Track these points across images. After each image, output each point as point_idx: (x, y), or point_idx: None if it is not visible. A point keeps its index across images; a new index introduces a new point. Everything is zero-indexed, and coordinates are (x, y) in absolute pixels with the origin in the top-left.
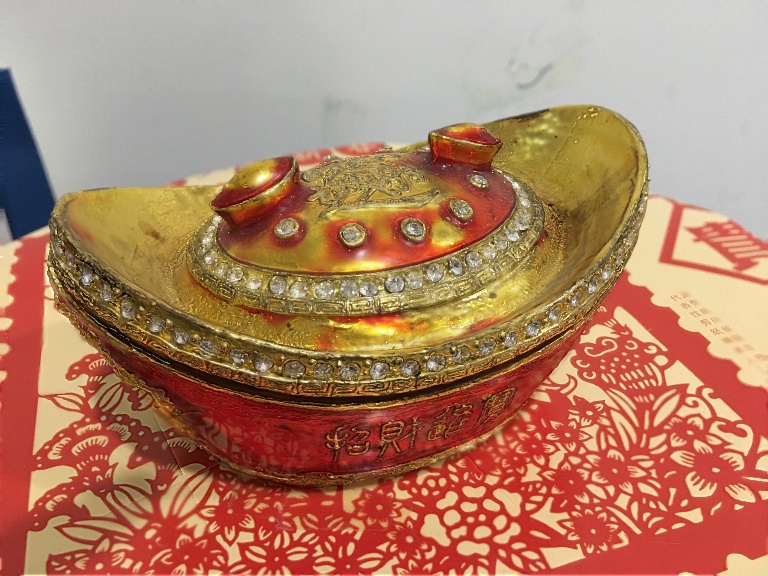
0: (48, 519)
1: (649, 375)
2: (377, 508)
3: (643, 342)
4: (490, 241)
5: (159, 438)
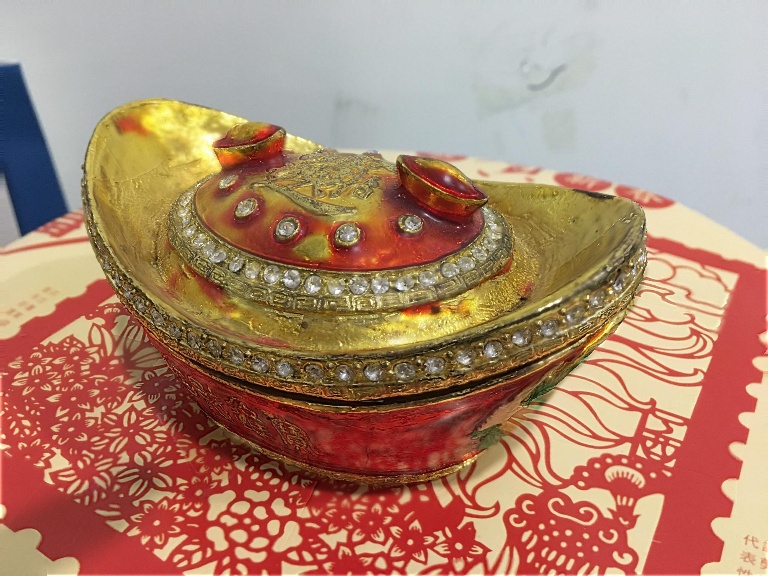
0: (97, 316)
1: (576, 574)
2: (215, 457)
3: (628, 545)
4: (346, 278)
5: None
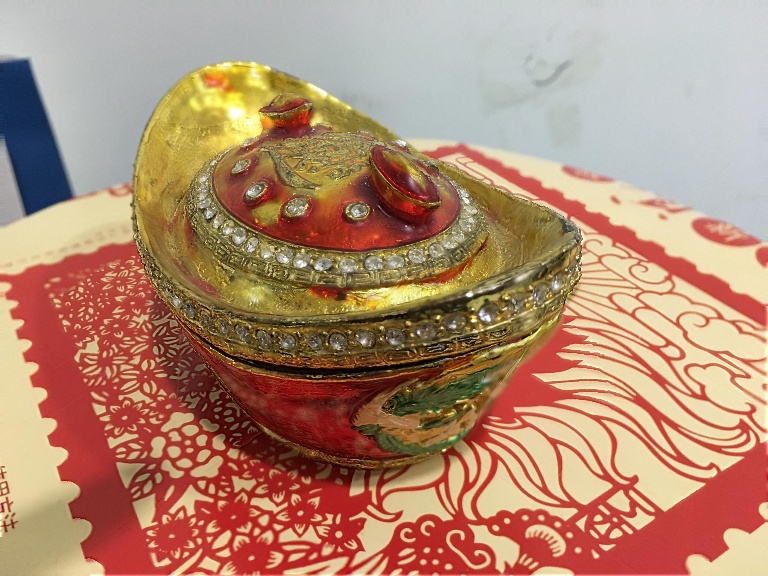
0: None
1: None
2: (199, 383)
3: None
4: (278, 246)
5: None
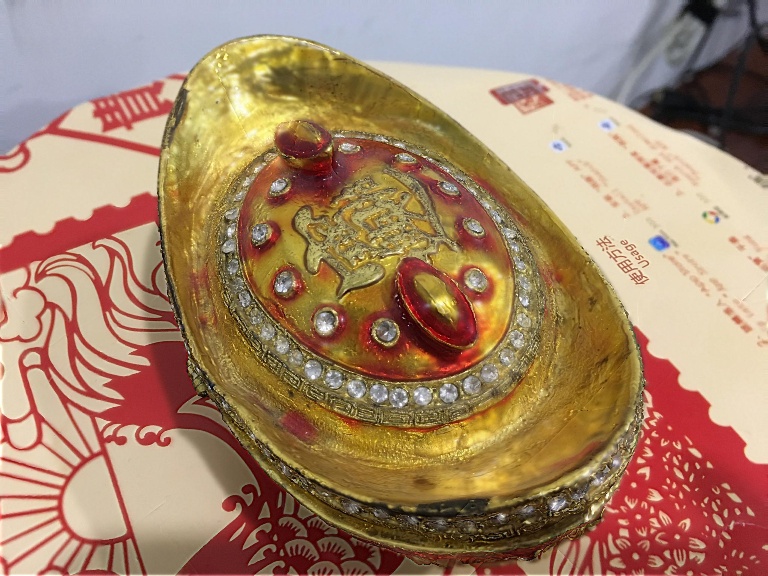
0: None
1: None
2: None
3: None
4: None
5: (486, 569)
